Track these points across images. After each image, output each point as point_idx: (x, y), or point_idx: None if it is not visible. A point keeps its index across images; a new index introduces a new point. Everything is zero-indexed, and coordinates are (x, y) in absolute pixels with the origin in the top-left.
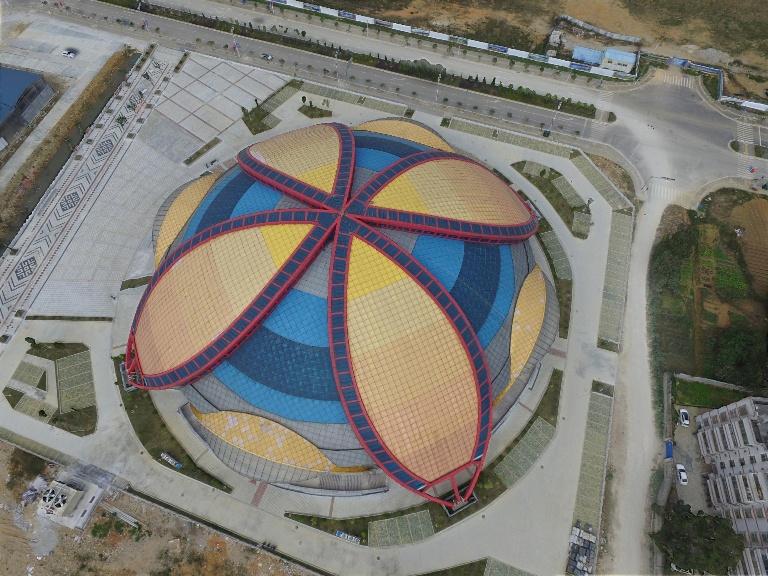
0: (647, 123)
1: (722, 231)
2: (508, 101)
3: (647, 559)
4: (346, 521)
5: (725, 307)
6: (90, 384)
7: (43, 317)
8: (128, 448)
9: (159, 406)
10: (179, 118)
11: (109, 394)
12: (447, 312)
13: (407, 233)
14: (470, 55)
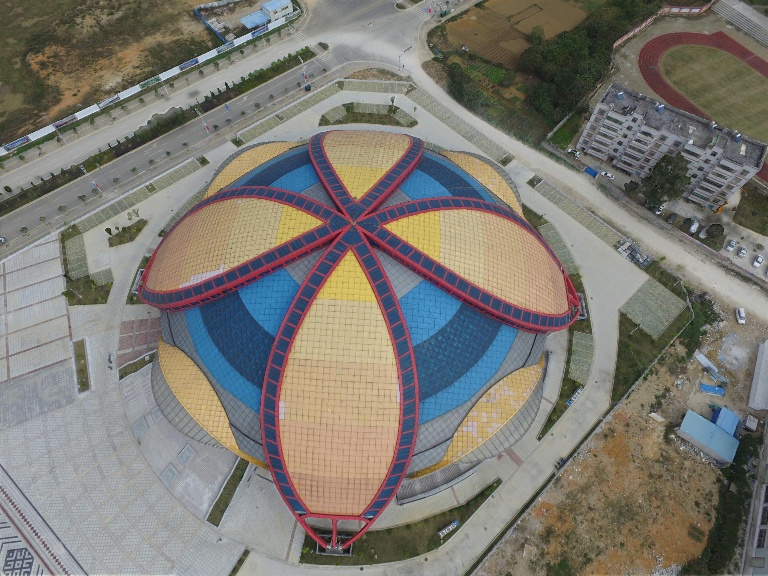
0: (345, 32)
1: (460, 55)
2: (252, 91)
3: (648, 224)
4: (561, 393)
5: (512, 89)
6: None
7: None
8: (414, 574)
9: (384, 525)
10: (0, 374)
11: None
12: (477, 208)
13: (394, 194)
14: (175, 85)
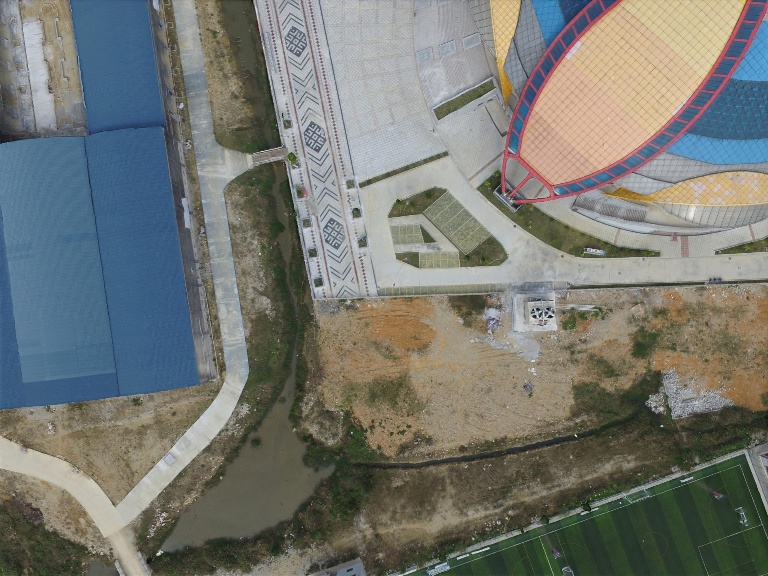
0: None
1: None
2: None
3: None
4: None
5: None
6: (472, 220)
7: (377, 178)
8: (547, 257)
9: (551, 213)
10: None
11: (497, 221)
12: None
13: None
14: None
